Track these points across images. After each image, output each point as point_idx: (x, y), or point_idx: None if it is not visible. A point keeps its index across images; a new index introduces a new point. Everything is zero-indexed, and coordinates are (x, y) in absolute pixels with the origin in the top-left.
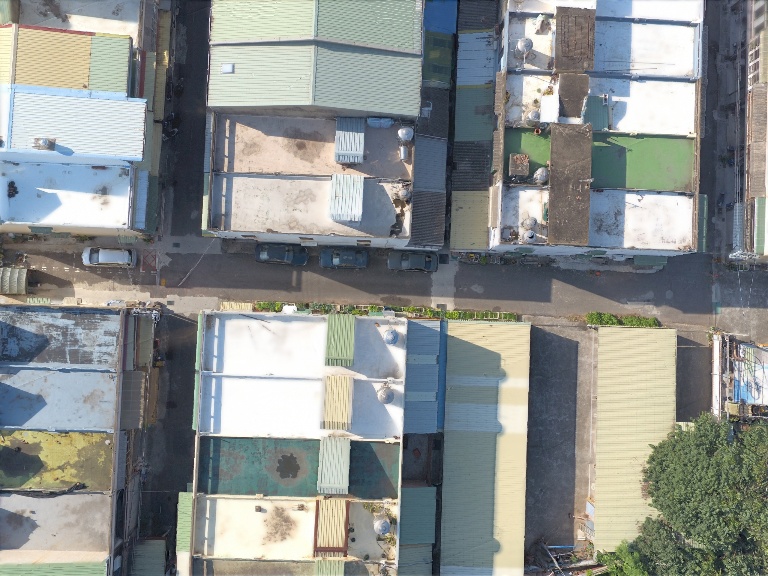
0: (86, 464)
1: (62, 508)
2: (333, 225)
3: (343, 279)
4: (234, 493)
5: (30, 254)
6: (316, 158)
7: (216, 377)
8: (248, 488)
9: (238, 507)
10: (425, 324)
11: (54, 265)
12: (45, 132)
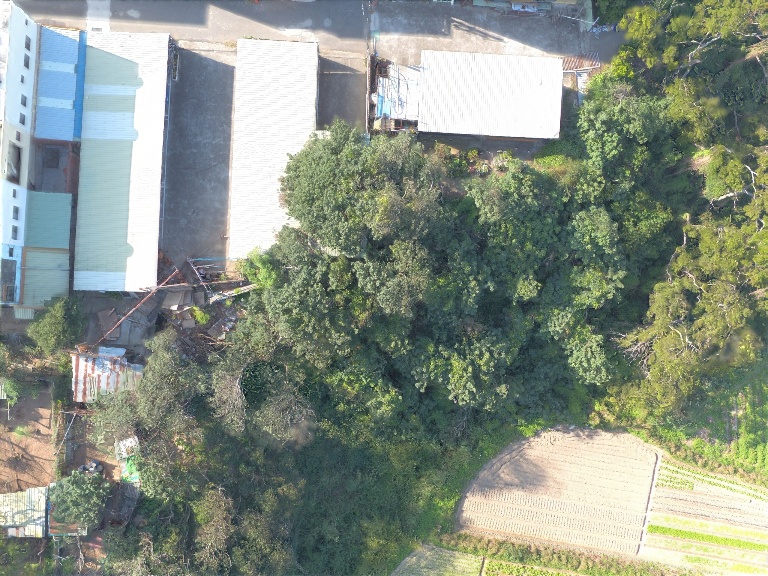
0: None
1: None
2: None
3: None
4: None
5: None
6: None
7: None
8: None
9: None
10: (63, 33)
11: None
12: None
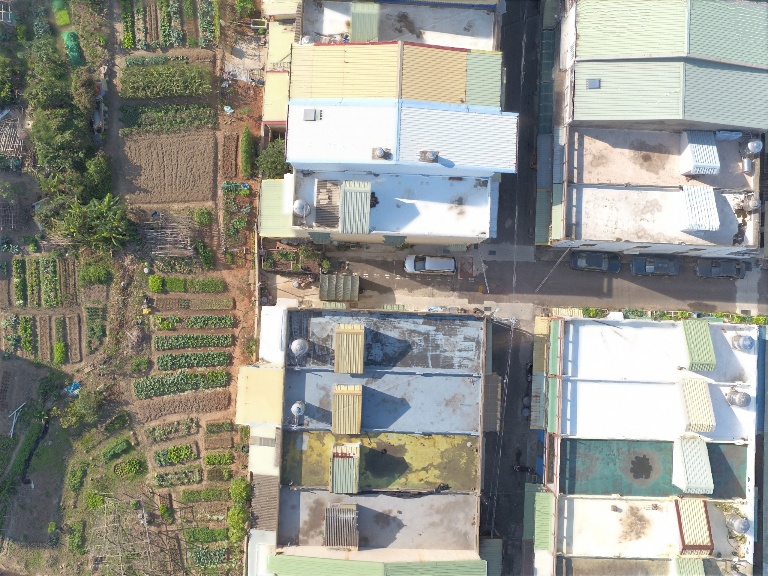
0: (449, 465)
1: (427, 508)
2: (679, 234)
3: (652, 286)
4: (591, 493)
5: (352, 261)
6: (661, 170)
7: (571, 381)
8: (604, 488)
9: (595, 507)
10: None
11: (375, 272)
12: (428, 145)
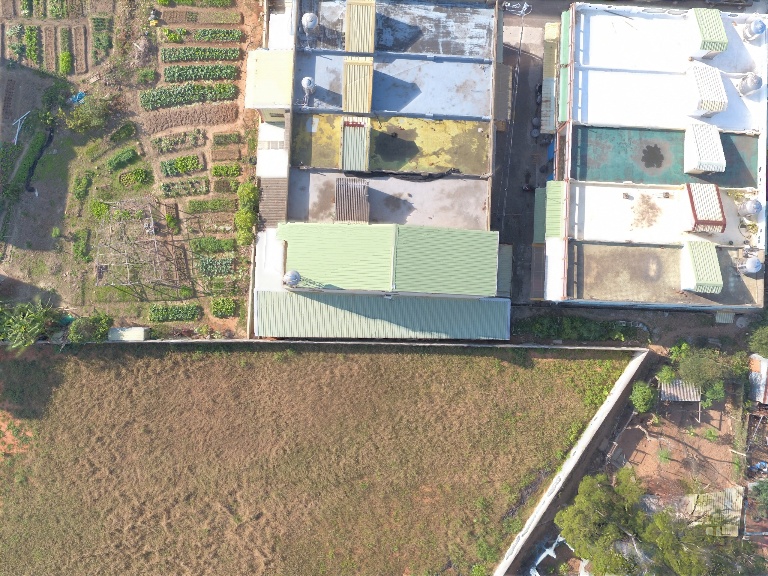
0: (460, 151)
1: (438, 192)
2: None
3: None
4: (602, 180)
5: None
6: None
7: (583, 70)
8: (615, 176)
9: (606, 194)
10: None
11: None
12: None
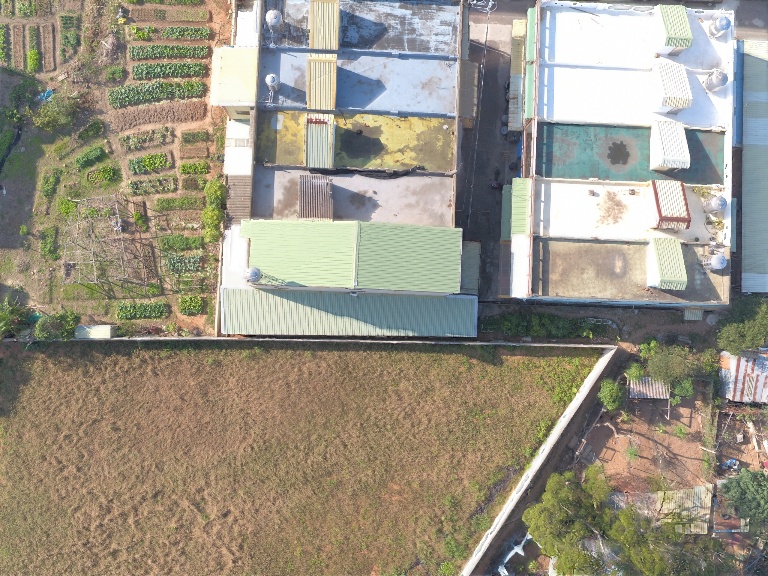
0: (425, 148)
1: (403, 189)
2: None
3: None
4: (568, 177)
5: None
6: None
7: (548, 67)
8: (581, 173)
9: (572, 191)
10: None
11: None
12: None
